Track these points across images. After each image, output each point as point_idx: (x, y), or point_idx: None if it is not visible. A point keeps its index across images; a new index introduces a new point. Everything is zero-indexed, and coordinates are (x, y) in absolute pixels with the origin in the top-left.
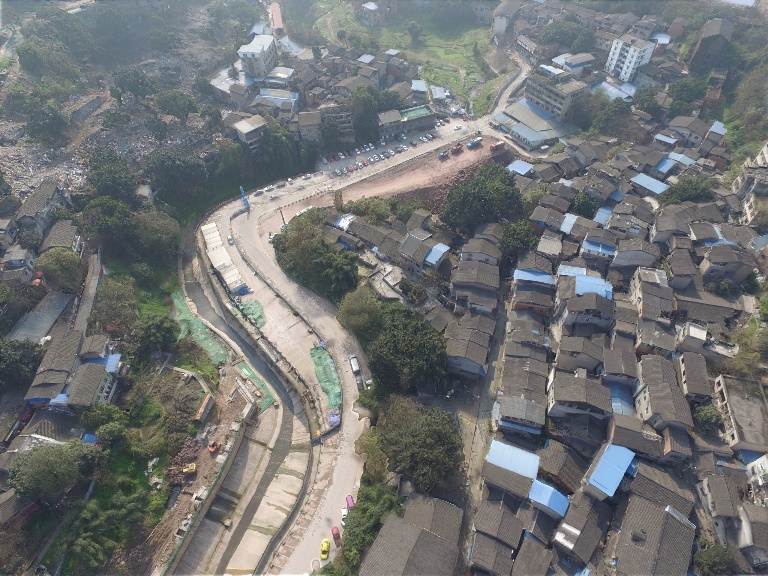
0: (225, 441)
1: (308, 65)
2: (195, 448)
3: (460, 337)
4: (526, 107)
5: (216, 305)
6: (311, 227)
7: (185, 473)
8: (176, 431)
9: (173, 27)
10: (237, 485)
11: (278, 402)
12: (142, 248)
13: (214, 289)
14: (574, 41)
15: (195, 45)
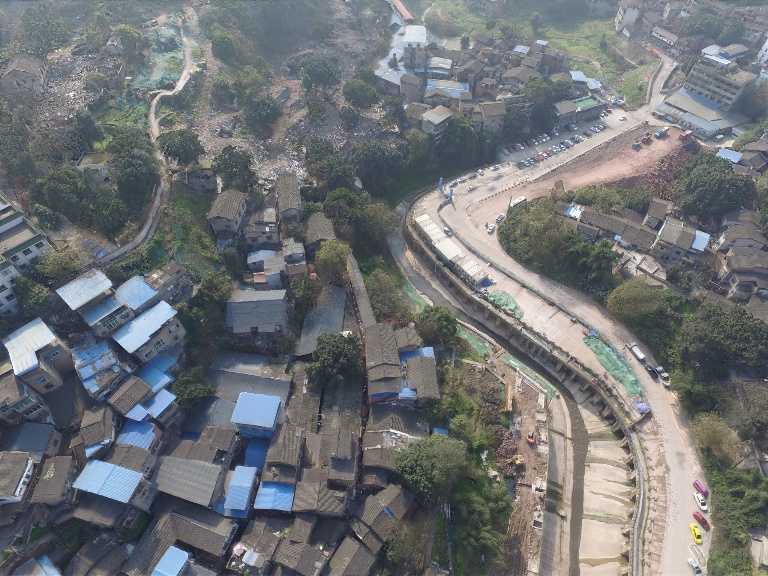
0: (537, 432)
1: (469, 55)
2: (512, 440)
3: (765, 321)
4: (688, 97)
5: (450, 297)
6: (553, 217)
7: (516, 465)
8: (492, 423)
9: (324, 17)
10: (556, 475)
11: (558, 392)
12: (366, 241)
13: (442, 281)
14: (722, 32)
15: (346, 35)
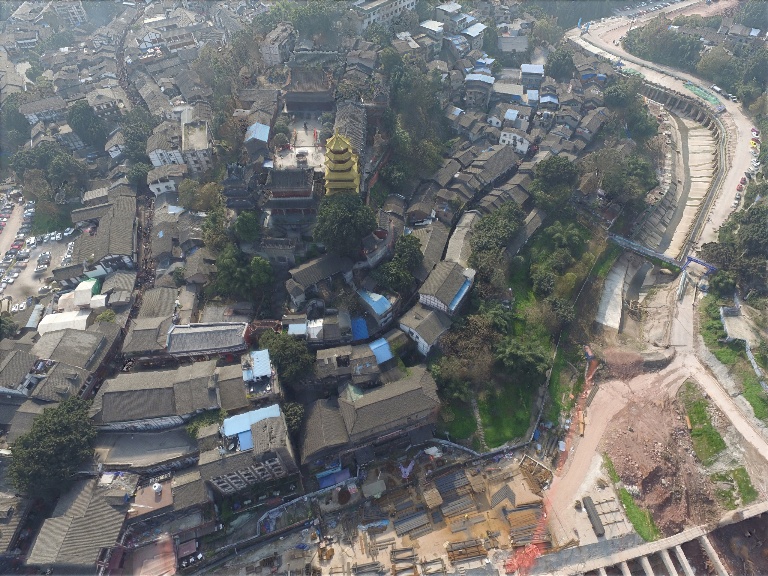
0: (662, 117)
1: None
2: None
3: None
4: None
5: None
6: None
7: None
8: None
9: None
10: (672, 139)
11: None
12: None
13: None
14: None
15: None
